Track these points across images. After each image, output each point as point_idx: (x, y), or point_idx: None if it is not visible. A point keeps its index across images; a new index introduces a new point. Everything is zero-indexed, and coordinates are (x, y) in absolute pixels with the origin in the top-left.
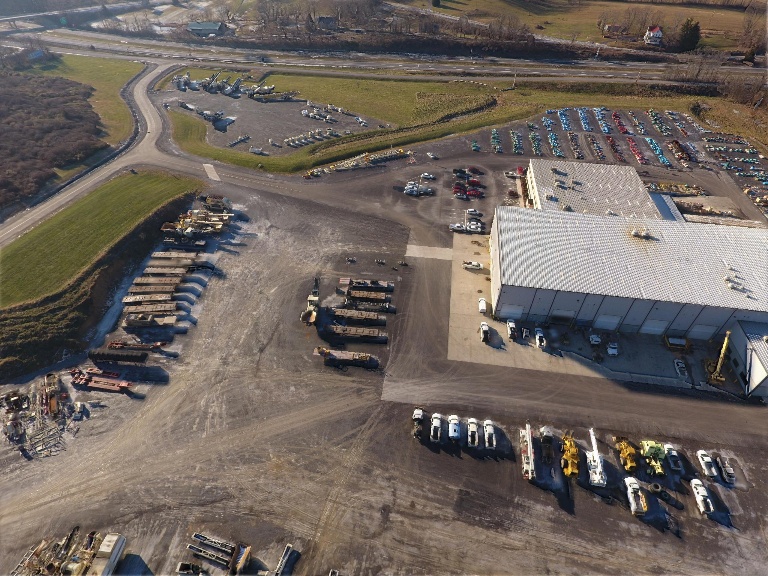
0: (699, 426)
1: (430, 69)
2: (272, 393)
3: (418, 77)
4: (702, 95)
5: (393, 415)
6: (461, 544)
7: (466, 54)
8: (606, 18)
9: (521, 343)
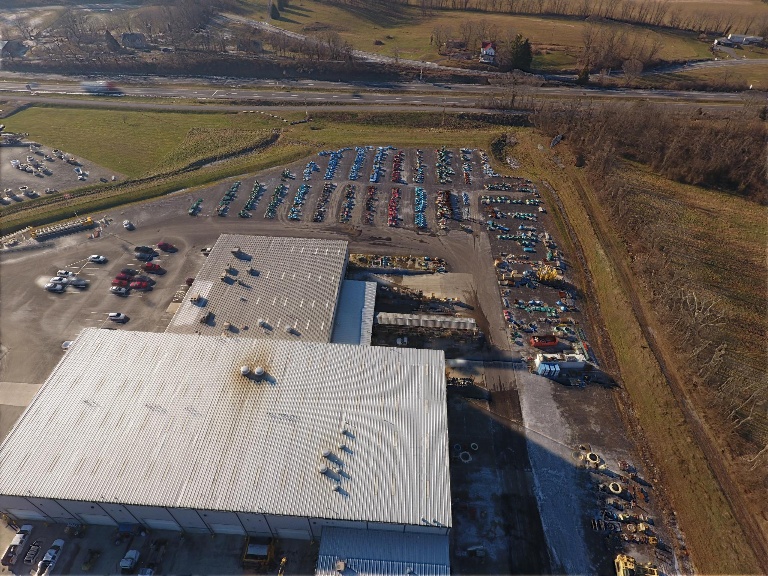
0: None
1: (226, 97)
2: None
3: (205, 107)
4: (515, 125)
5: None
6: None
7: (279, 76)
8: (438, 33)
9: (18, 572)
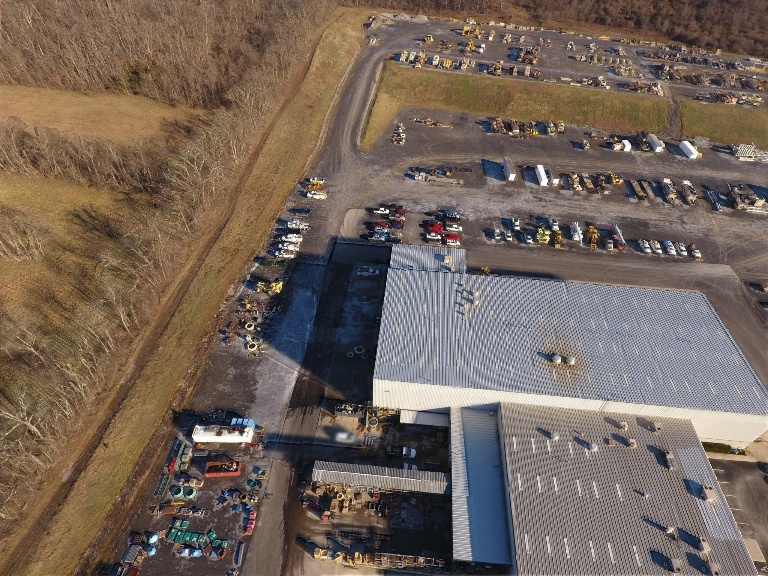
0: (505, 254)
1: None
2: None
3: None
4: None
5: (713, 257)
6: (639, 213)
7: None
8: None
9: None
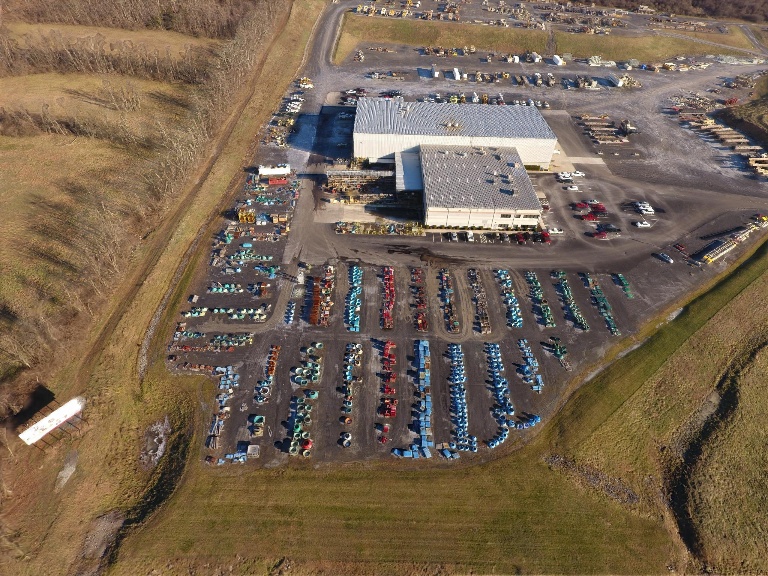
0: None
1: None
2: (612, 111)
3: None
4: None
5: None
6: None
7: None
8: None
9: None
